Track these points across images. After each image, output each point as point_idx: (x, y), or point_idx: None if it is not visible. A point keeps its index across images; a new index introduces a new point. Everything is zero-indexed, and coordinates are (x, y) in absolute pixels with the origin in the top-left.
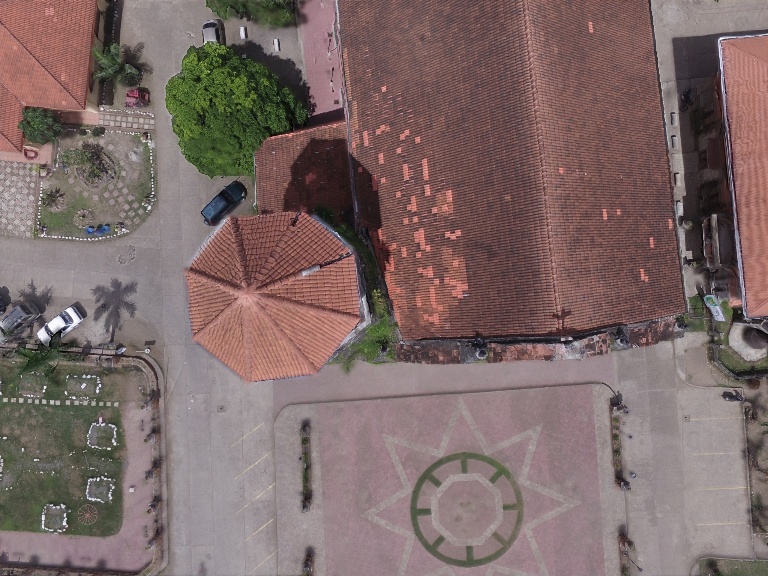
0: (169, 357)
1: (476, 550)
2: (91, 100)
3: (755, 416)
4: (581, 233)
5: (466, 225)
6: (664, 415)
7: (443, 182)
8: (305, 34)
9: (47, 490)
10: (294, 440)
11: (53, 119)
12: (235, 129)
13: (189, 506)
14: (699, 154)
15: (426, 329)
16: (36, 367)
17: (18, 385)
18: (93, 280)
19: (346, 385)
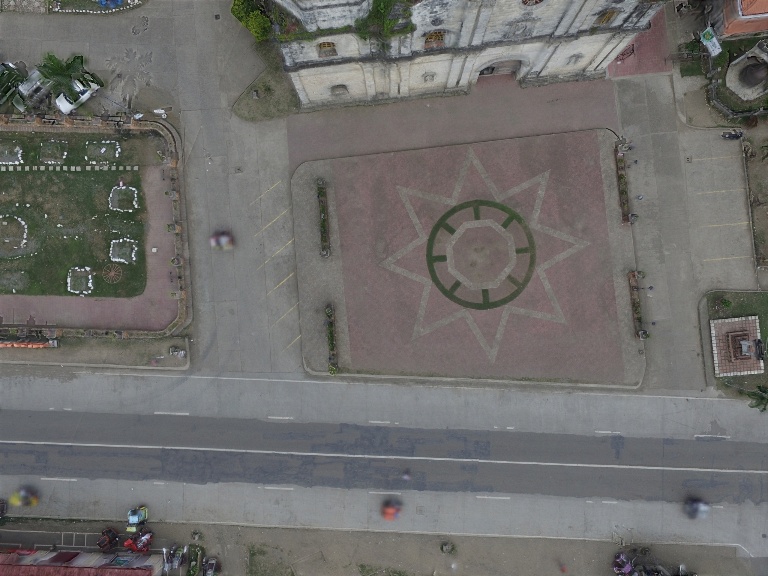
0: (186, 122)
1: (491, 293)
2: None
3: (754, 154)
4: None
5: None
6: (667, 157)
7: None
8: None
9: (71, 254)
10: (311, 195)
11: None
12: None
13: (211, 264)
14: None
15: None
16: (61, 77)
17: (39, 153)
18: (108, 51)
19: (359, 141)
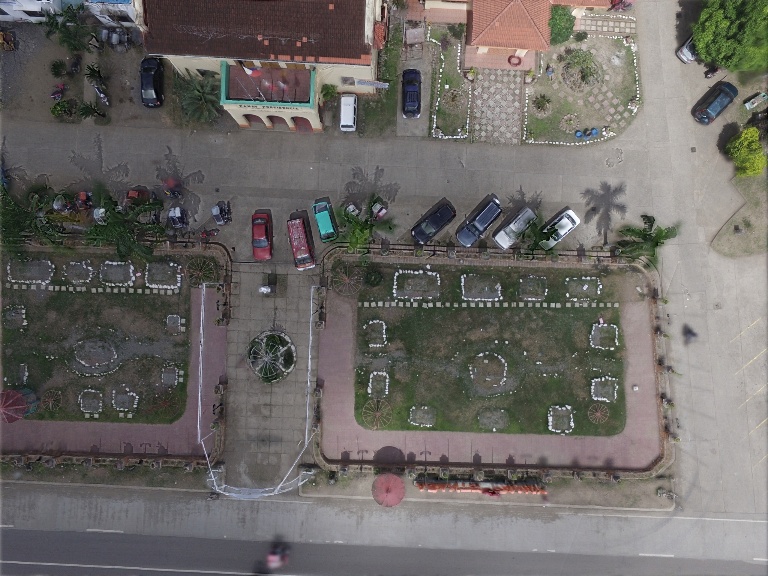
0: (663, 257)
1: None
2: None
3: None
4: None
5: None
6: None
7: None
8: None
9: (550, 392)
10: None
11: None
12: None
13: (691, 402)
14: None
15: None
16: None
17: (518, 289)
18: (582, 184)
19: None
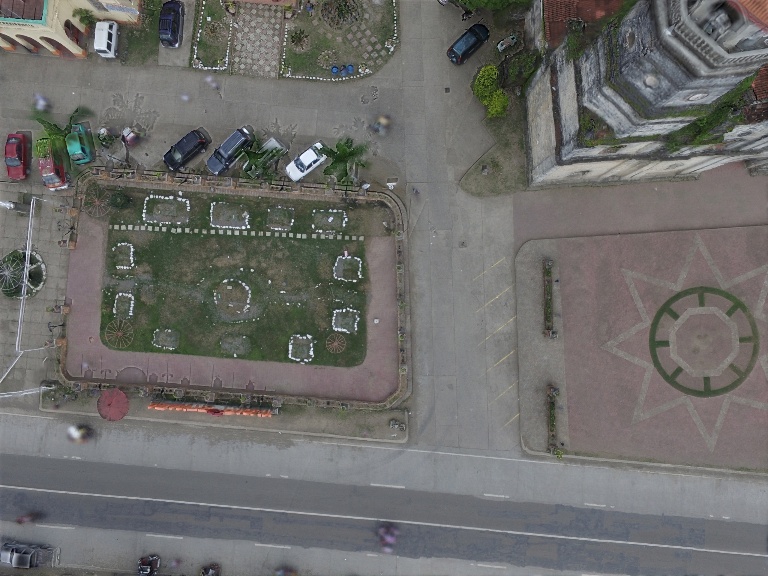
0: (411, 194)
1: (713, 381)
2: None
3: None
4: None
5: None
6: None
7: None
8: None
9: (293, 321)
10: (535, 274)
11: None
12: None
13: (432, 338)
14: None
15: None
16: (342, 163)
17: (265, 219)
18: (336, 119)
19: (585, 221)
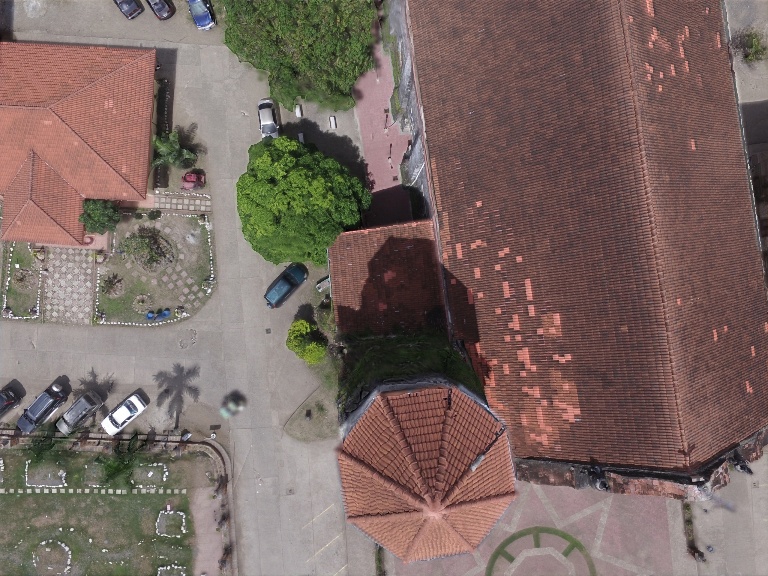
0: (235, 441)
1: None
2: (148, 185)
3: None
4: (698, 361)
5: (577, 350)
6: (733, 482)
7: (550, 305)
8: (361, 110)
9: None
10: None
11: (113, 209)
12: (311, 228)
13: None
14: (760, 221)
15: (533, 449)
16: (118, 476)
17: (83, 476)
18: (155, 366)
19: None
